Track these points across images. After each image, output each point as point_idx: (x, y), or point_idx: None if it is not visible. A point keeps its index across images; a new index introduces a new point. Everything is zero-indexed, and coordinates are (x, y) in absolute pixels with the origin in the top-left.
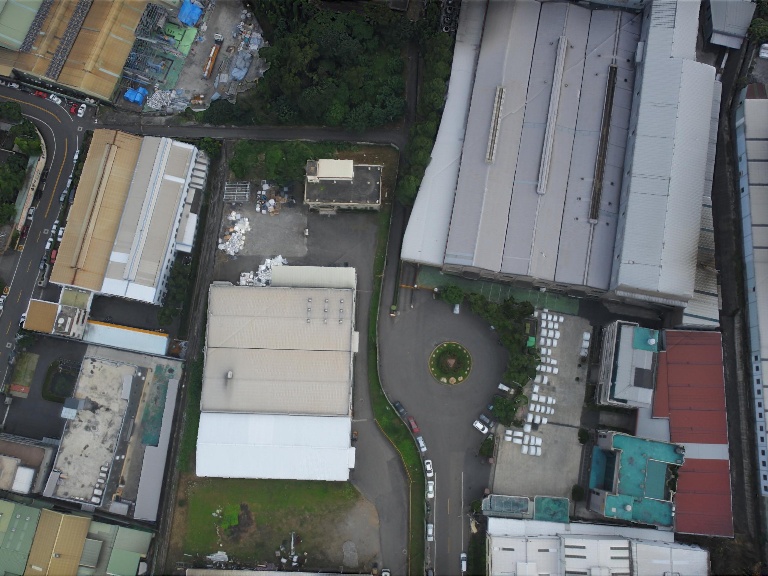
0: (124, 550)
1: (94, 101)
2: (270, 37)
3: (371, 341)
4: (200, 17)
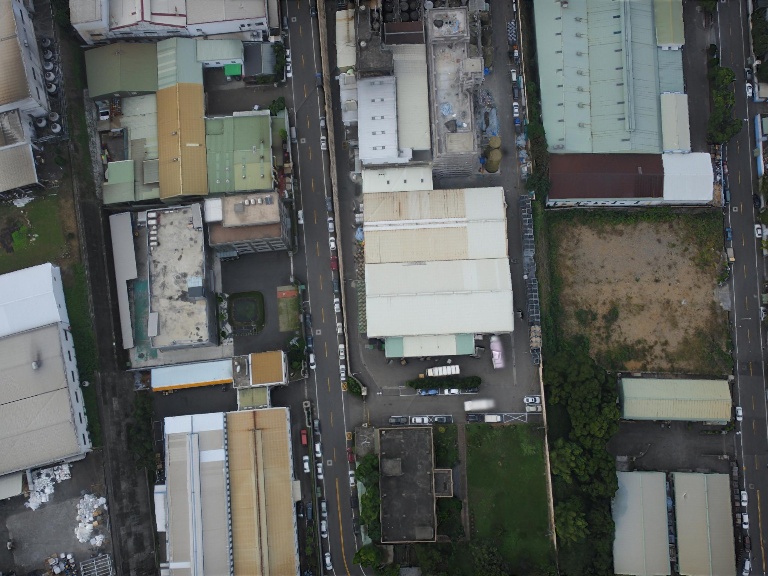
0: (123, 183)
1: None
2: None
3: None
4: None
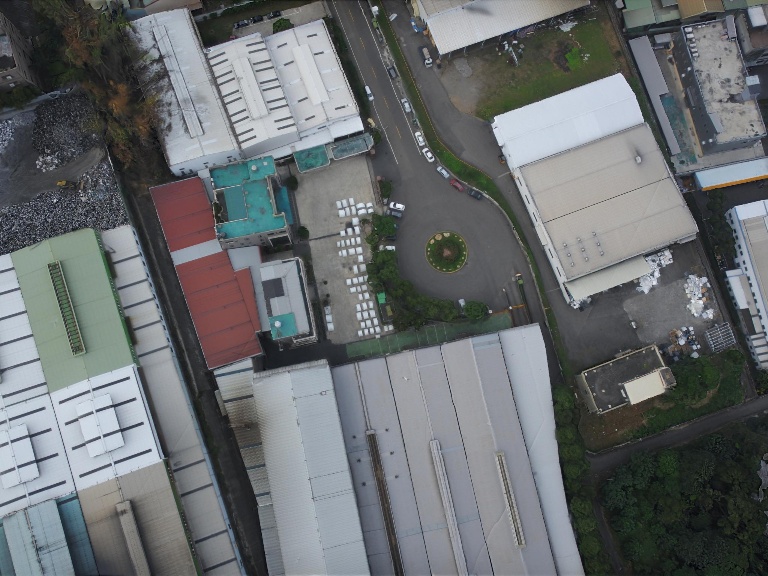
0: (643, 8)
1: None
2: None
3: (526, 245)
4: None
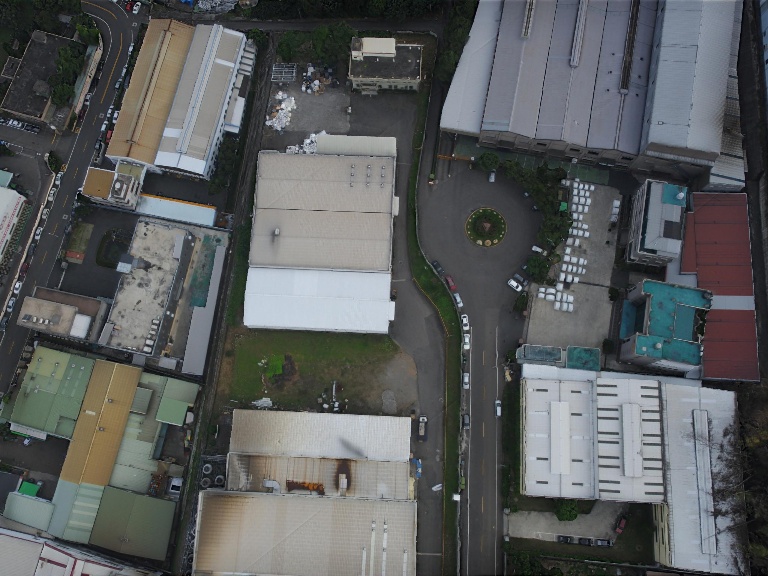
0: (173, 399)
1: None
2: None
3: (410, 207)
4: None
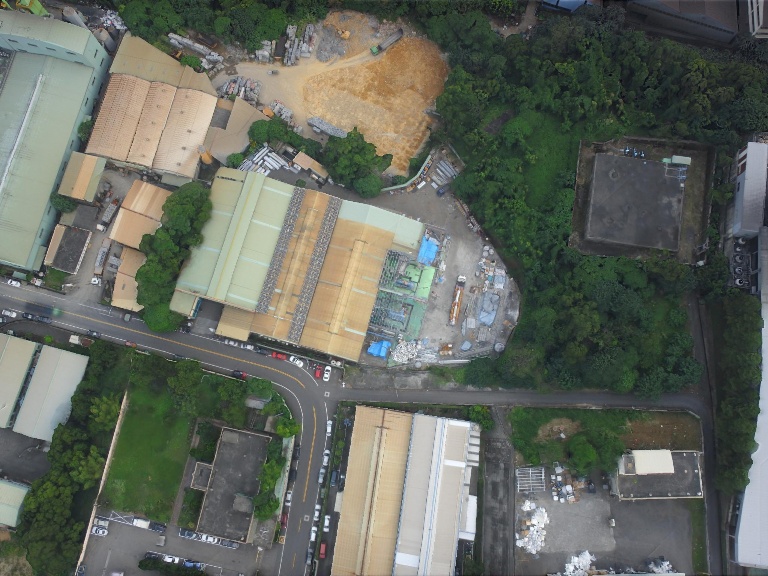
0: None
1: (340, 363)
2: (517, 275)
3: None
4: (436, 254)
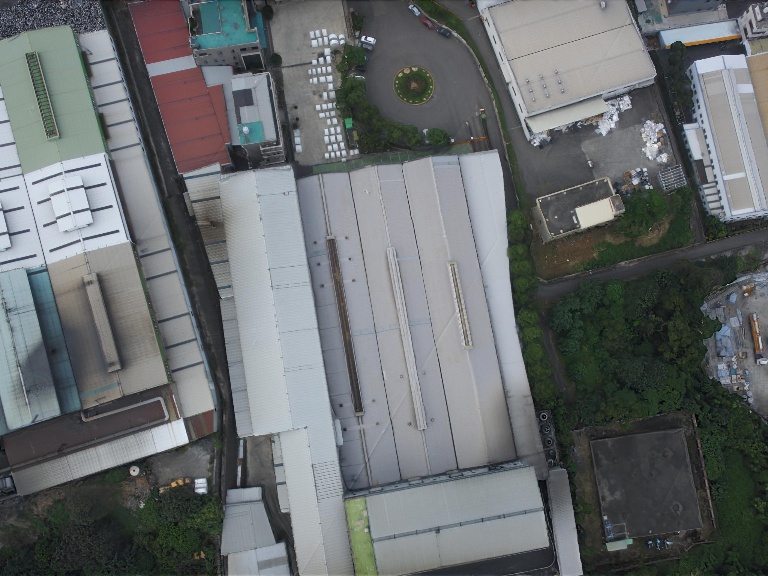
0: None
1: None
2: None
3: (491, 84)
4: None
